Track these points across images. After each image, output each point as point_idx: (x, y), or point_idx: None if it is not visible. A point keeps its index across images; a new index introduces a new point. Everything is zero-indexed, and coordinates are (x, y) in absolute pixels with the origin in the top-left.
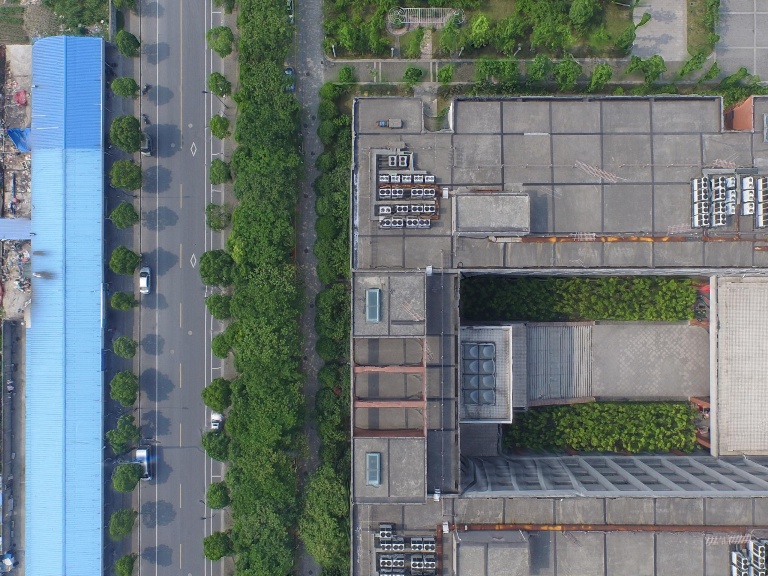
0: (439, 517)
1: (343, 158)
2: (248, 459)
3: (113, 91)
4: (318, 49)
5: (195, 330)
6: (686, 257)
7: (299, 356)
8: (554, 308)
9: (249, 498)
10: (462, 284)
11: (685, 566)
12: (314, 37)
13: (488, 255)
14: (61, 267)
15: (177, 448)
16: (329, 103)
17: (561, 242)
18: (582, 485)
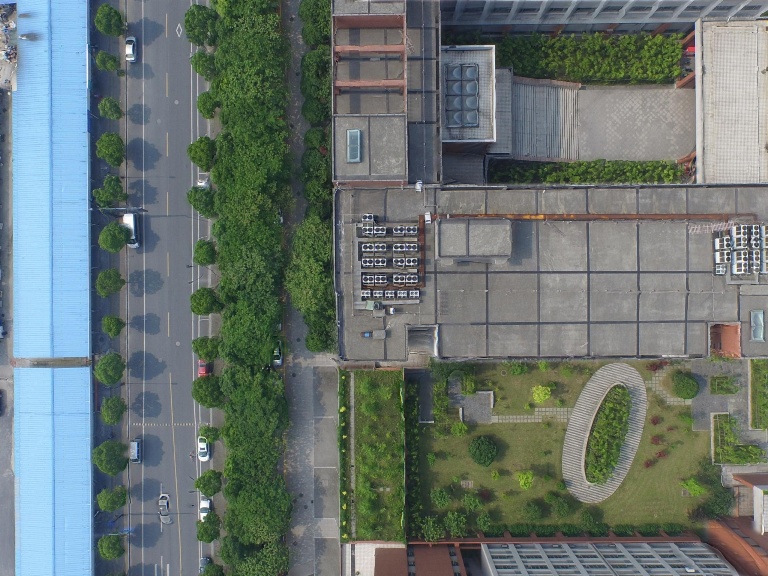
0: (421, 208)
1: None
2: (233, 204)
3: None
4: None
5: (181, 99)
6: None
7: (284, 106)
8: (539, 63)
9: (235, 243)
10: (447, 41)
11: (668, 255)
12: None
13: None
14: (46, 28)
15: (164, 217)
16: None
17: None
18: None
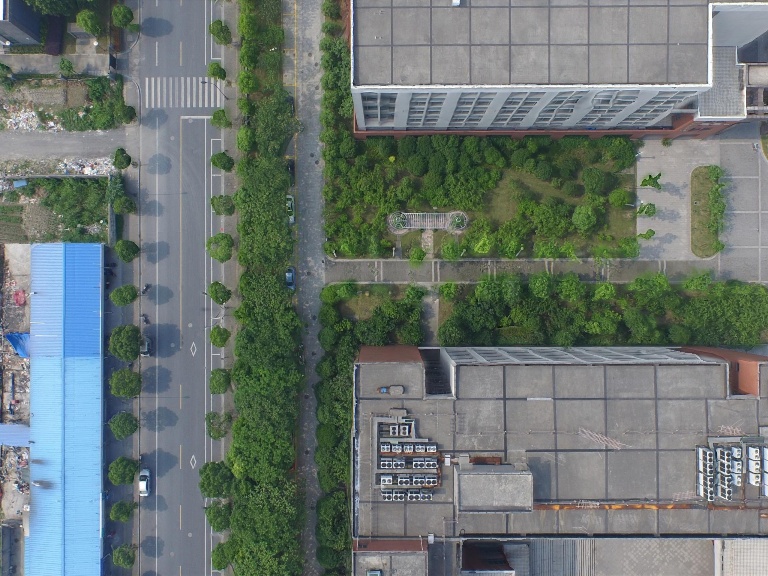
0: None
1: (344, 366)
2: None
3: (112, 301)
4: (319, 248)
5: (195, 532)
6: (691, 524)
7: (300, 574)
8: None
9: None
10: None
11: None
12: (315, 236)
13: (491, 522)
14: (60, 477)
15: None
16: (330, 310)
17: (564, 509)
18: None
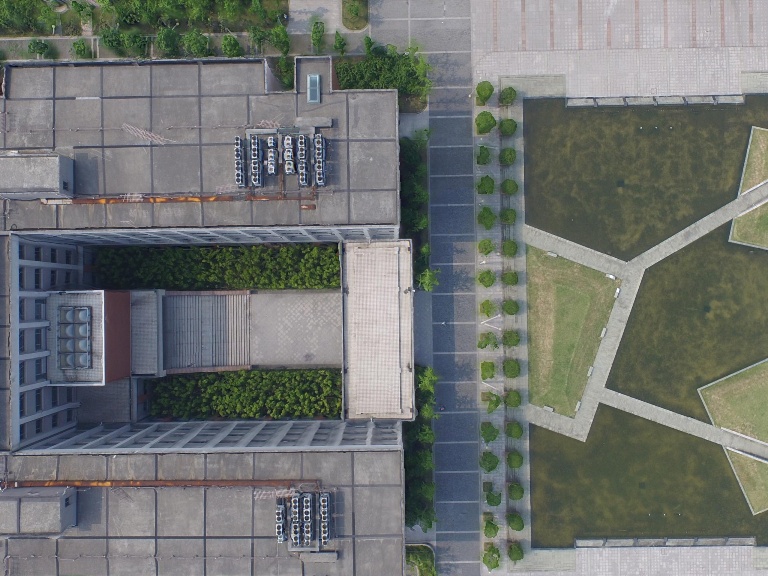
0: None
1: None
2: None
3: None
4: None
5: None
6: (235, 216)
7: None
8: (198, 277)
9: None
10: (109, 254)
11: (234, 520)
12: None
13: (41, 217)
14: None
15: None
16: None
17: (112, 203)
18: (154, 444)
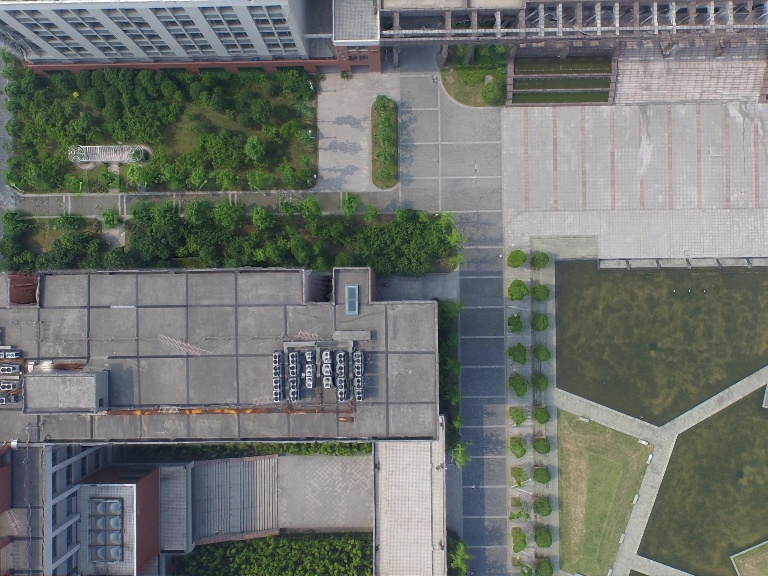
0: None
1: None
2: None
3: None
4: None
5: None
6: (271, 428)
7: None
8: (226, 445)
9: None
10: None
11: None
12: (4, 172)
13: (75, 428)
14: None
15: None
16: (7, 242)
17: (147, 414)
18: None
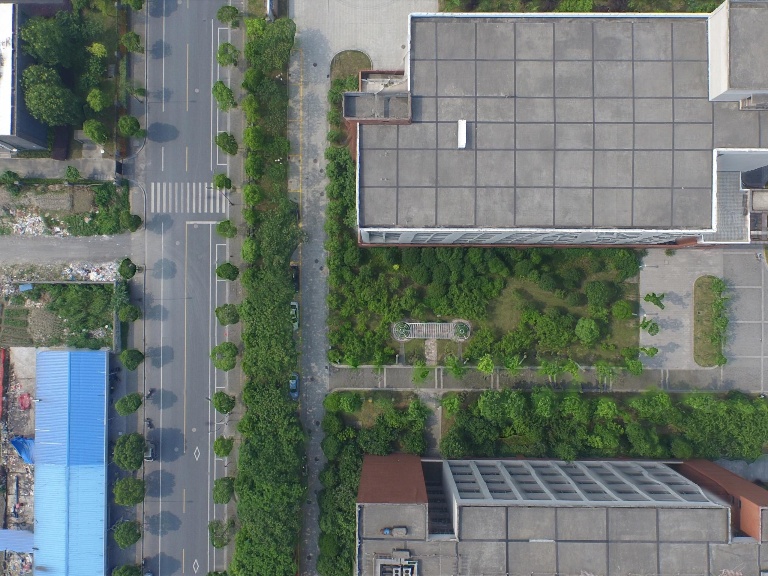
0: None
1: (347, 476)
2: None
3: (117, 411)
4: (323, 354)
5: None
6: None
7: None
8: None
9: None
10: None
11: None
12: (319, 342)
13: None
14: None
15: None
16: (333, 420)
17: None
18: None
